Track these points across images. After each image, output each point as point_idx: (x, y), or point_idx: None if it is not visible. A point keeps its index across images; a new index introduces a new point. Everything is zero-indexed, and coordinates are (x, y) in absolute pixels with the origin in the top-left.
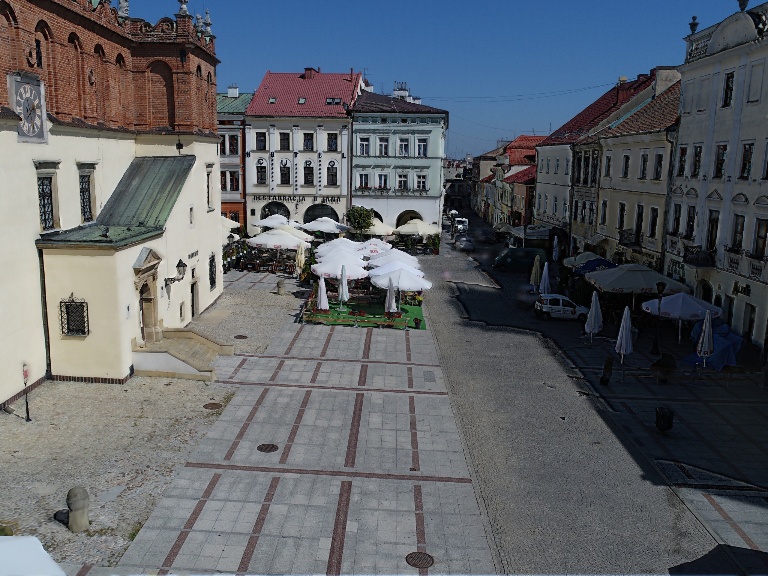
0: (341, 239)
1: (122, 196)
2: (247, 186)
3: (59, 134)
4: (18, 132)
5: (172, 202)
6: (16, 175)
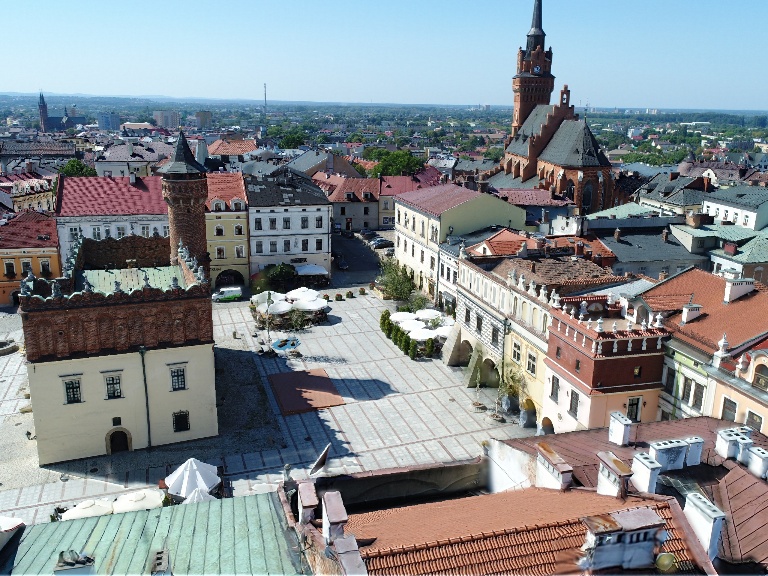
0: None
1: None
2: None
3: None
4: None
5: None
6: None
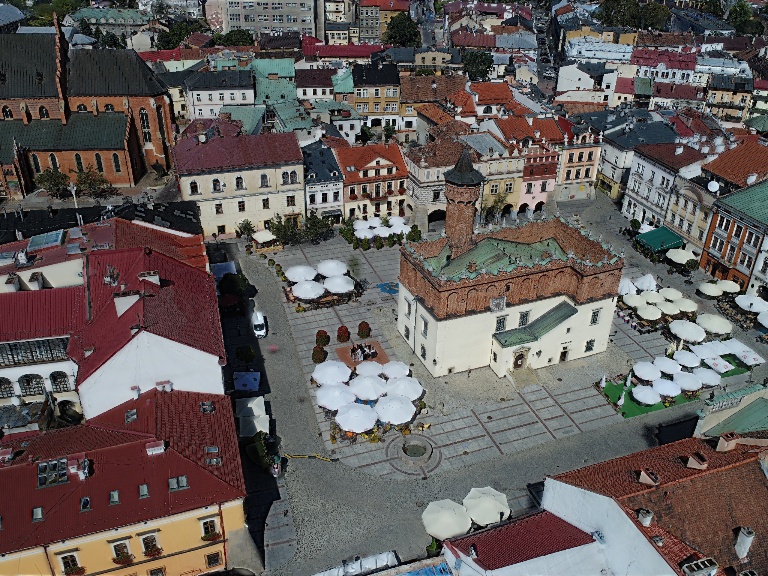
0: (733, 343)
1: (543, 318)
2: (755, 269)
3: (511, 307)
4: (492, 311)
5: (550, 329)
6: (487, 321)
